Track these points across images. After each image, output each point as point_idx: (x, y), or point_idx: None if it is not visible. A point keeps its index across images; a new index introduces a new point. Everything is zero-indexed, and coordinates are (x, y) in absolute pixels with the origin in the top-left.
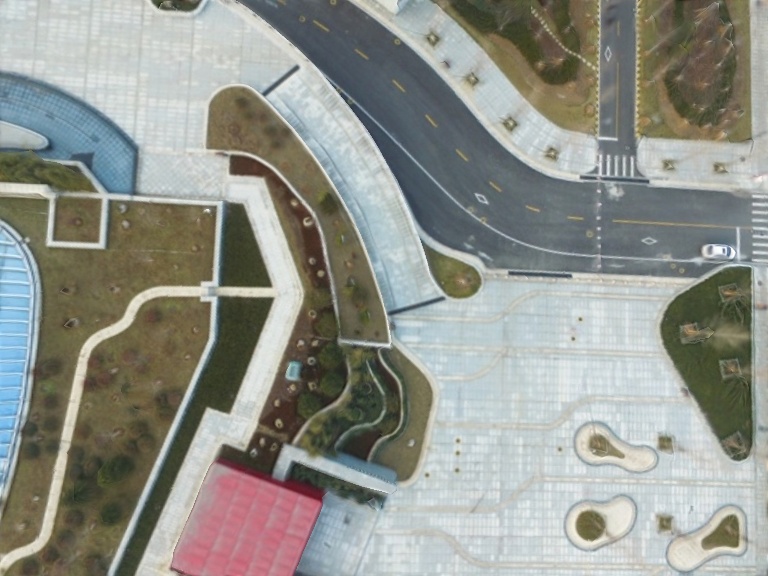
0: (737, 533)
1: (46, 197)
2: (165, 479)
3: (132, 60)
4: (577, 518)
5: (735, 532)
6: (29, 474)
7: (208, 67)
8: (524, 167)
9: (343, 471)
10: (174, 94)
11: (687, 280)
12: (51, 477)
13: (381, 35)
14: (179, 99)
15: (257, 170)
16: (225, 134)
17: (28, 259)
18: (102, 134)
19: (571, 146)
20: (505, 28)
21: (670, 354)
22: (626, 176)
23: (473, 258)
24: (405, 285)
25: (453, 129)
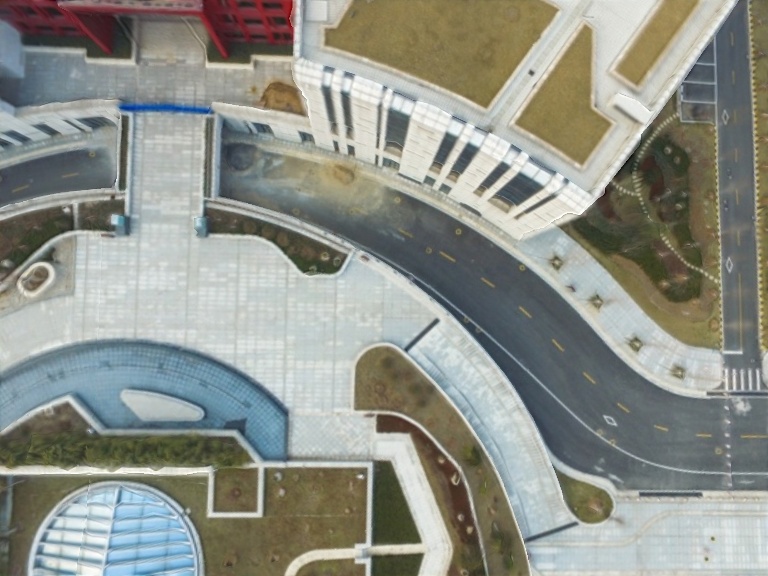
0: None
1: None
2: None
3: (279, 323)
4: None
5: None
6: None
7: (352, 326)
8: (651, 386)
9: None
10: (320, 355)
11: None
12: None
13: (506, 262)
14: (325, 360)
15: (404, 428)
16: (372, 394)
17: (190, 531)
18: (254, 400)
19: (697, 362)
20: (630, 251)
21: None
22: (752, 390)
23: (604, 481)
24: (539, 514)
25: (580, 352)
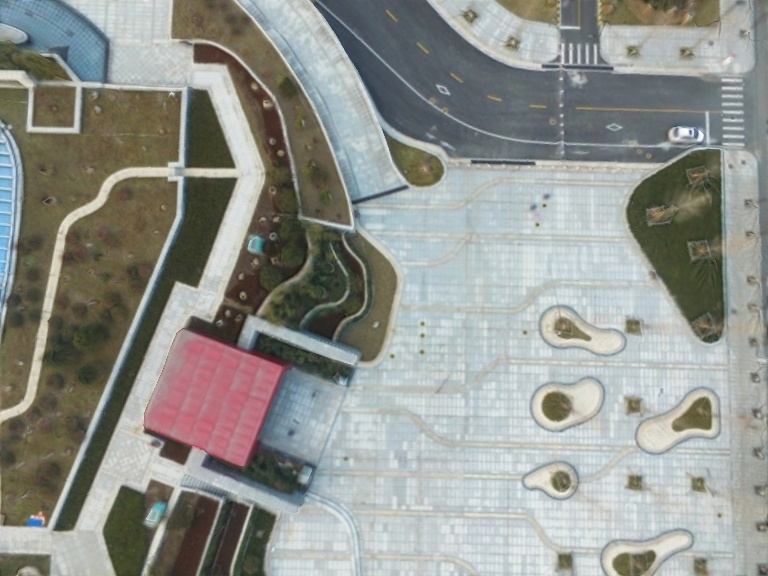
0: (709, 415)
1: (25, 86)
2: (138, 348)
3: None
4: (543, 399)
5: (707, 414)
6: (14, 342)
7: None
8: (485, 58)
9: (305, 341)
10: None
11: (654, 165)
12: (34, 345)
13: None
14: None
15: (219, 57)
16: (189, 24)
17: (10, 144)
18: (76, 29)
19: (532, 36)
20: None
21: (637, 237)
22: (589, 64)
23: (436, 148)
24: (368, 174)
25: (414, 23)
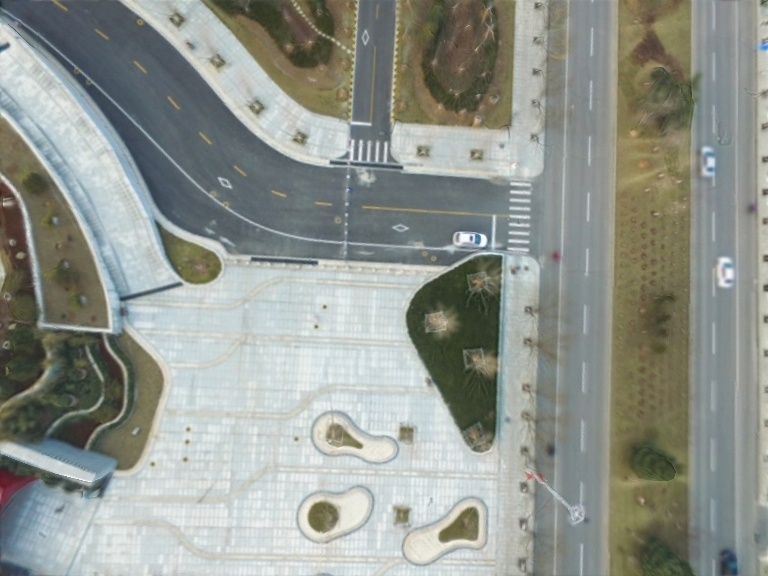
0: (476, 526)
1: None
2: None
3: None
4: (310, 509)
5: (474, 525)
6: None
7: None
8: (271, 151)
9: (37, 458)
10: None
11: (438, 268)
12: None
13: (123, 15)
14: None
15: None
16: None
17: None
18: None
19: (322, 130)
20: (250, 9)
21: (414, 343)
22: (379, 162)
23: (214, 243)
24: (139, 270)
25: (197, 112)
